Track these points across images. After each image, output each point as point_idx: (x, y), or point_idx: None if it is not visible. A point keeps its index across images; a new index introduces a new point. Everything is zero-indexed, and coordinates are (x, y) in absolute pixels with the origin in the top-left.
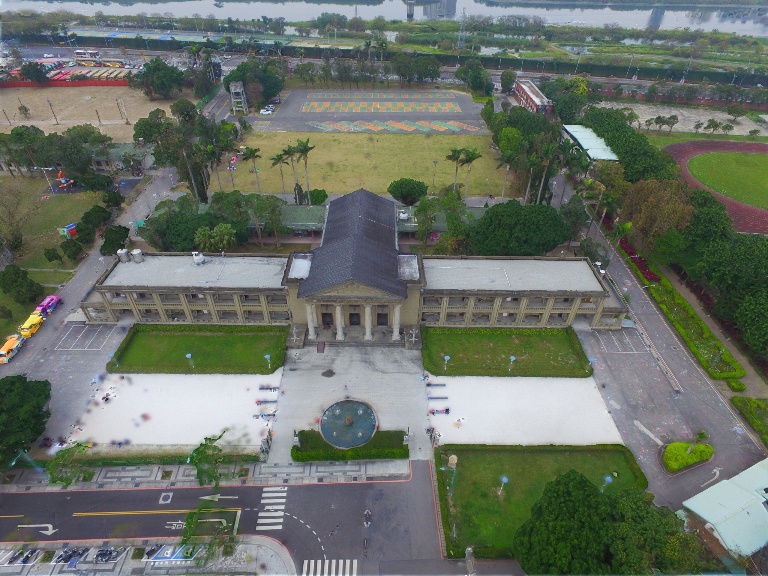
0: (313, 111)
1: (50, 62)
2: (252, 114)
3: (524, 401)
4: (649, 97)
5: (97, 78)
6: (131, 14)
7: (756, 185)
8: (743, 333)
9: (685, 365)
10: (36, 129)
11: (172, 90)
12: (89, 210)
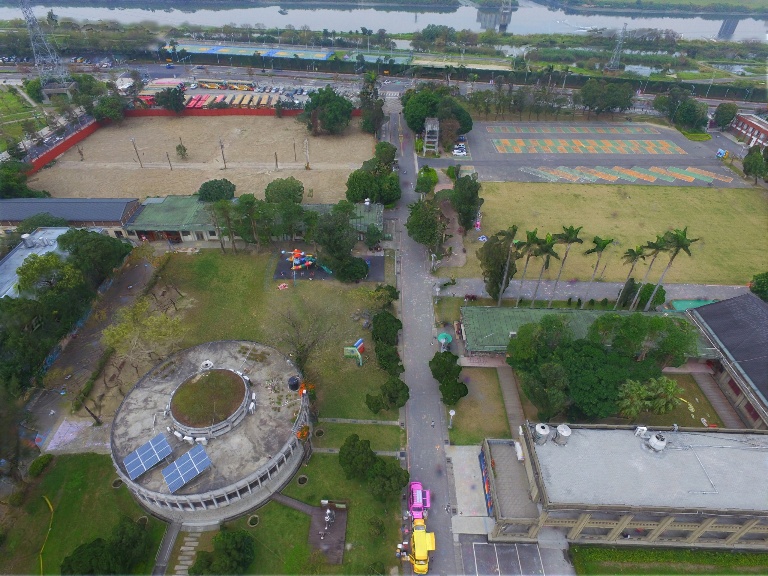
0: (512, 152)
1: (173, 85)
2: (444, 155)
3: None
4: None
5: (237, 106)
6: (268, 31)
7: None
8: None
9: None
10: (228, 183)
11: (341, 124)
12: (355, 310)
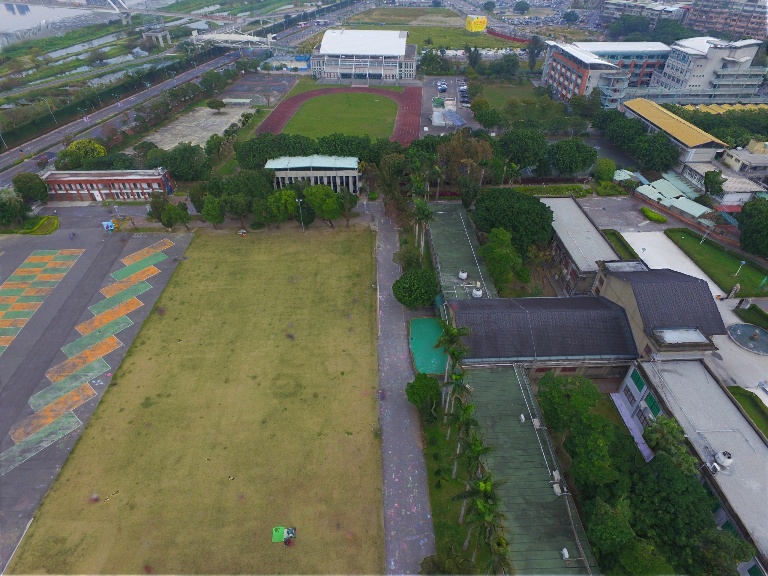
0: None
1: None
2: None
3: (657, 260)
4: (147, 127)
5: None
6: None
7: (346, 134)
8: None
9: None
10: None
11: None
12: None
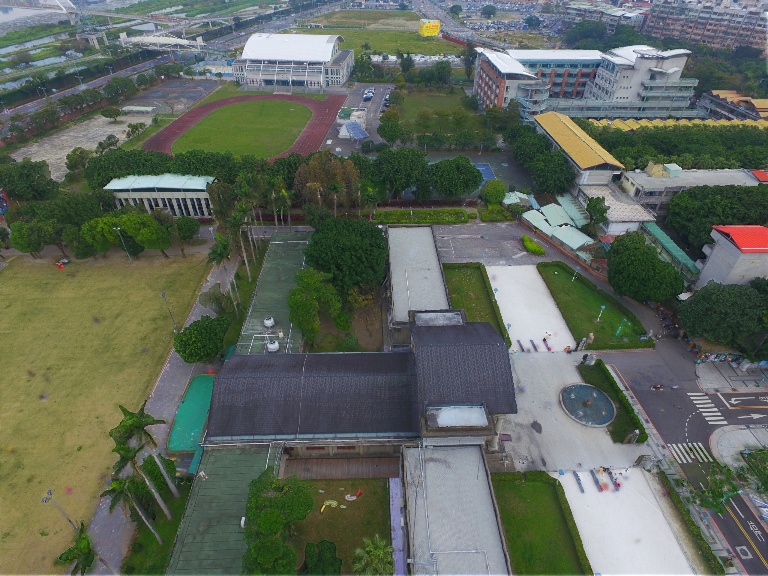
0: None
1: None
2: None
3: (516, 300)
4: (24, 137)
5: None
6: None
7: (240, 147)
8: (429, 200)
9: (458, 229)
10: None
11: None
12: None
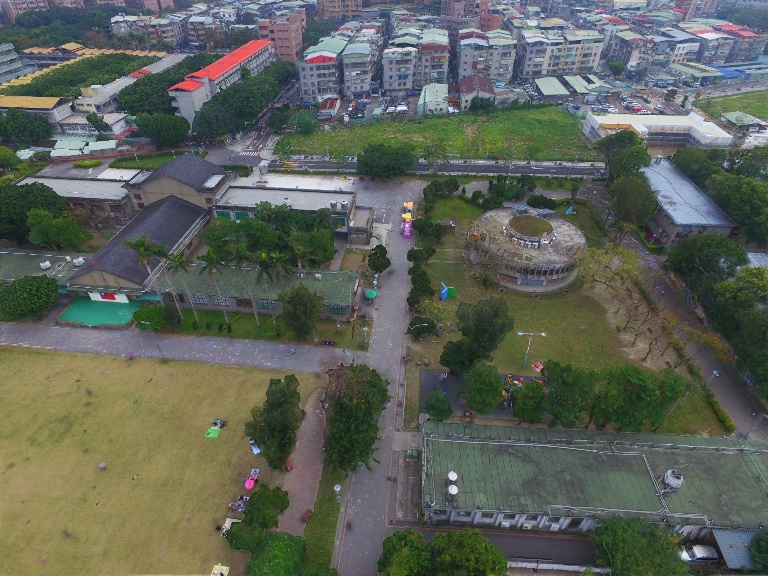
0: None
1: None
2: None
3: None
4: None
5: None
6: None
7: None
8: None
9: None
10: None
11: None
12: None
